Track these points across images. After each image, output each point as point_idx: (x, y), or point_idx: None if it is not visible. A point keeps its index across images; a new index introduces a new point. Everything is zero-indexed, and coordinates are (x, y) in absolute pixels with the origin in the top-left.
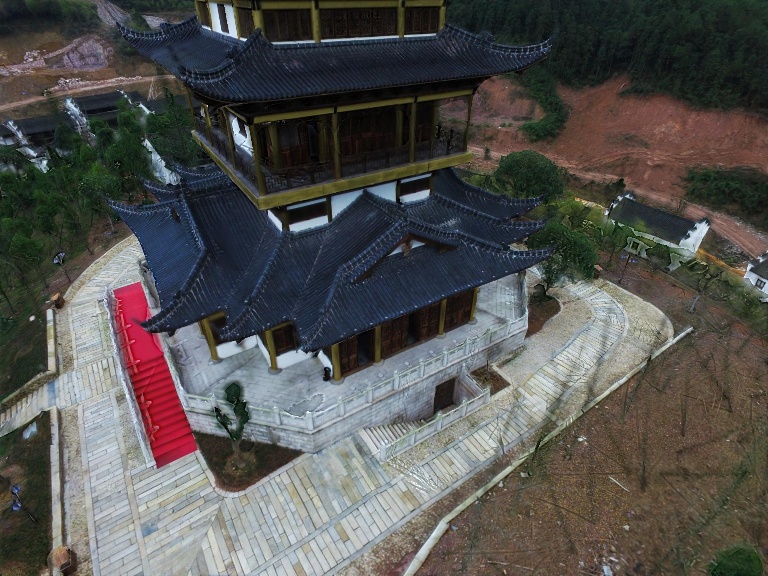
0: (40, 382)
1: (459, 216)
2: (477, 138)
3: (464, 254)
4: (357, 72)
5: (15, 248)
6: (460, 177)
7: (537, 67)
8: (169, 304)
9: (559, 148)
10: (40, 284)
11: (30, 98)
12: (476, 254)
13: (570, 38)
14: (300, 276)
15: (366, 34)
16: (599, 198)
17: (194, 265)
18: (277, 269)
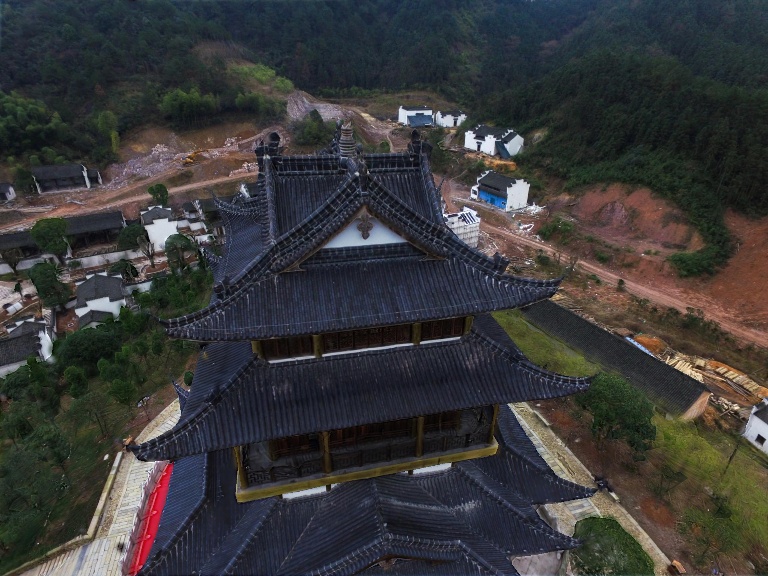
0: (78, 543)
1: (481, 499)
2: (613, 263)
3: (462, 571)
4: (346, 401)
5: (112, 390)
6: (546, 366)
7: (702, 190)
8: (146, 567)
9: (716, 289)
10: (134, 408)
11: (219, 178)
12: (477, 575)
13: (750, 162)
14: (277, 556)
15: (375, 344)
16: (757, 369)
17: (186, 517)
18: (256, 544)
